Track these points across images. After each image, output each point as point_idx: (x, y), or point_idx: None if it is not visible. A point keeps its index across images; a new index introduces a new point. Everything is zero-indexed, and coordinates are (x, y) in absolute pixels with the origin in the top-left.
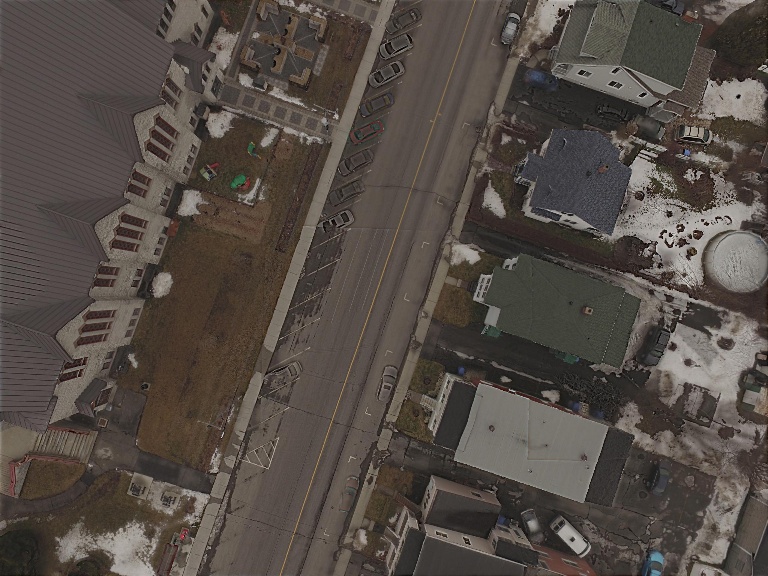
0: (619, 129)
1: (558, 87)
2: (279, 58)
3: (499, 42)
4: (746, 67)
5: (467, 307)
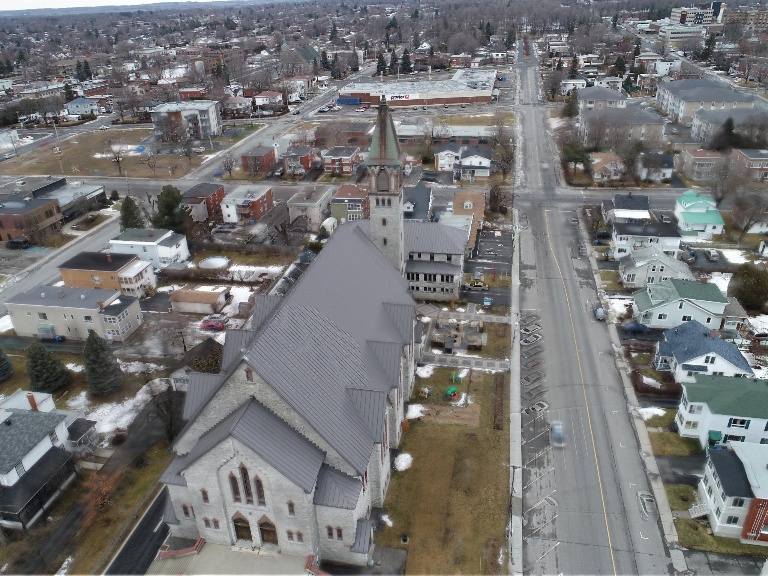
0: None
1: (650, 331)
2: (458, 339)
3: (596, 320)
4: (762, 305)
5: (679, 441)
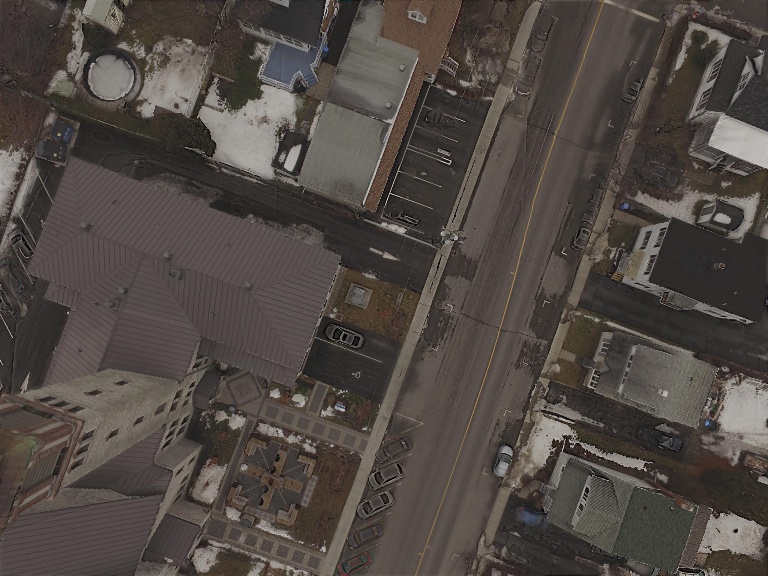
0: (612, 562)
1: None
2: (266, 496)
3: (491, 472)
4: None
5: None
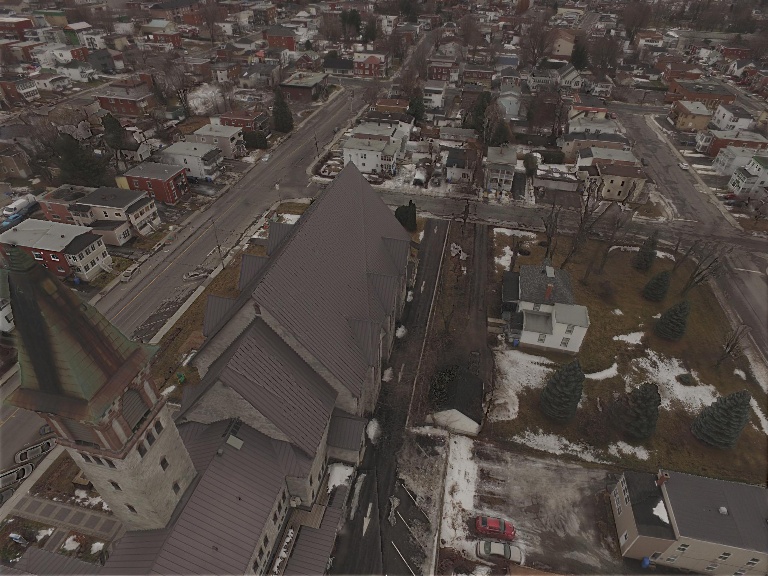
0: None
1: None
2: None
3: None
4: None
5: None
